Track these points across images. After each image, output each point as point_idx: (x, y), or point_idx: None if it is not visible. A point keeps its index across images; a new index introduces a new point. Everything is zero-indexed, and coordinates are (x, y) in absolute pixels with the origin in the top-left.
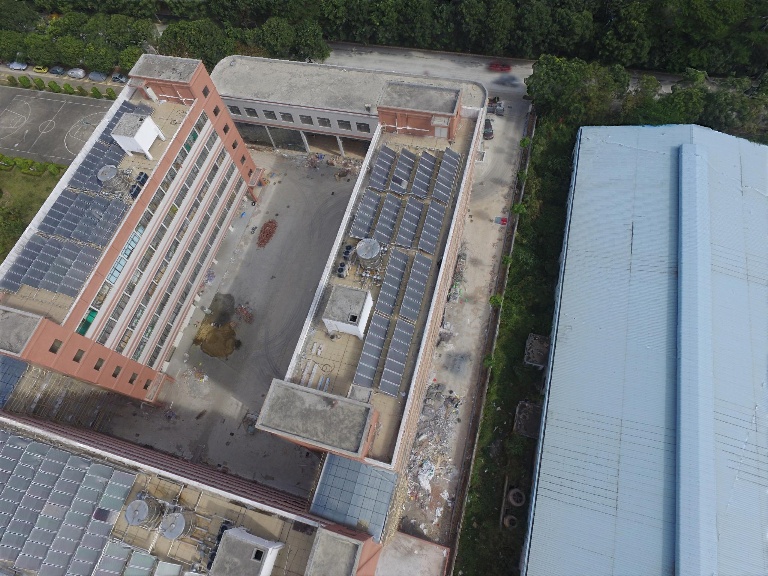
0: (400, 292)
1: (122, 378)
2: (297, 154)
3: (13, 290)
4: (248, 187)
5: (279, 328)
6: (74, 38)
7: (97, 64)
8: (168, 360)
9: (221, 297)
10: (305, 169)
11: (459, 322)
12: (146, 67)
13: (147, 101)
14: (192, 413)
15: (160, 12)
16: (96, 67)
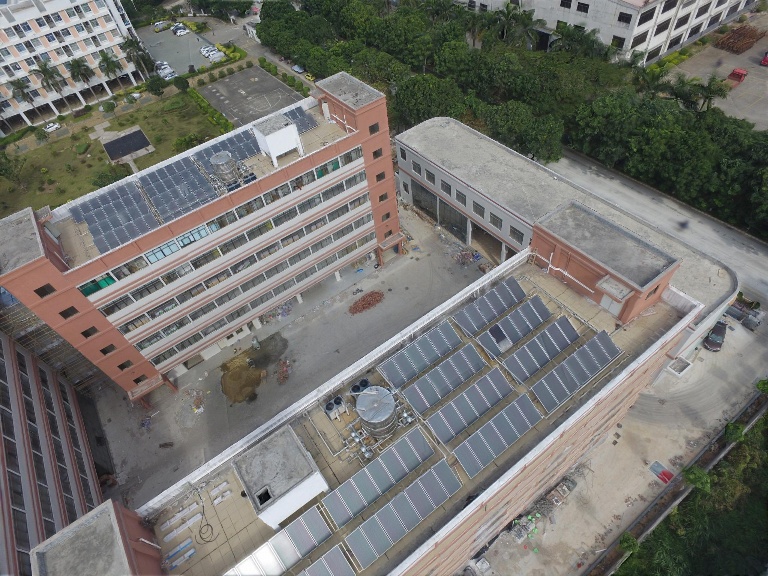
0: (381, 500)
1: (112, 358)
2: (455, 241)
3: (77, 220)
4: (378, 246)
5: None
6: (344, 61)
7: None
8: (189, 367)
9: (278, 338)
10: (452, 260)
11: (504, 573)
12: (336, 84)
13: (320, 116)
14: (161, 437)
15: (430, 68)
16: None
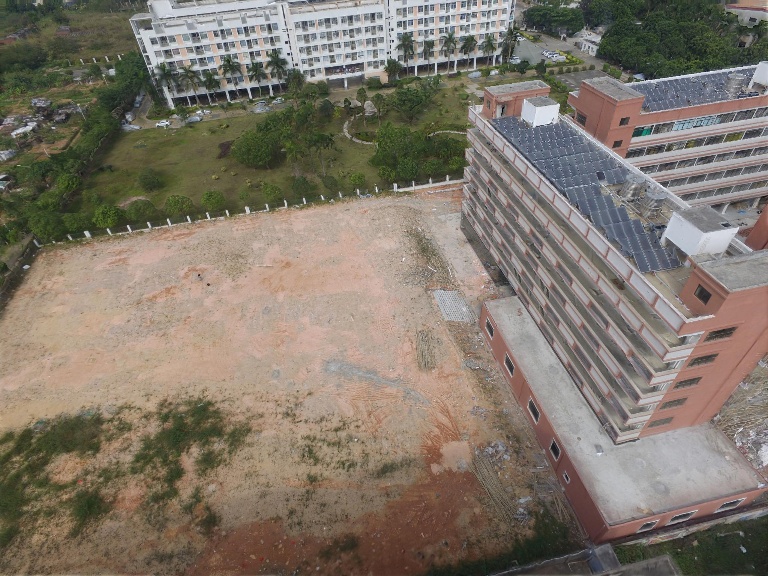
0: None
1: None
2: None
3: None
4: None
5: None
6: None
7: None
8: None
9: None
10: None
11: None
12: None
13: None
14: None
15: None
16: None
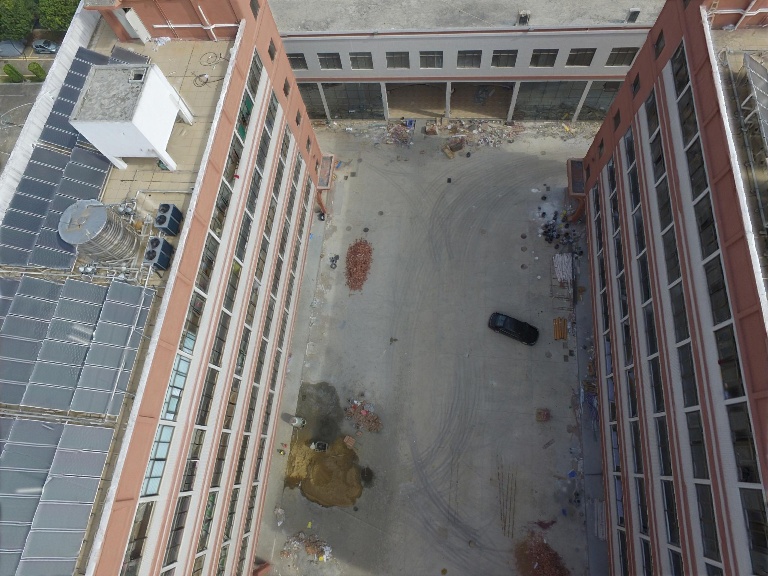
0: None
1: None
2: (369, 124)
3: None
4: (317, 191)
5: (433, 434)
6: None
7: (4, 26)
8: None
9: (311, 390)
10: (390, 147)
11: None
12: None
13: (127, 45)
14: None
15: None
16: (3, 31)
